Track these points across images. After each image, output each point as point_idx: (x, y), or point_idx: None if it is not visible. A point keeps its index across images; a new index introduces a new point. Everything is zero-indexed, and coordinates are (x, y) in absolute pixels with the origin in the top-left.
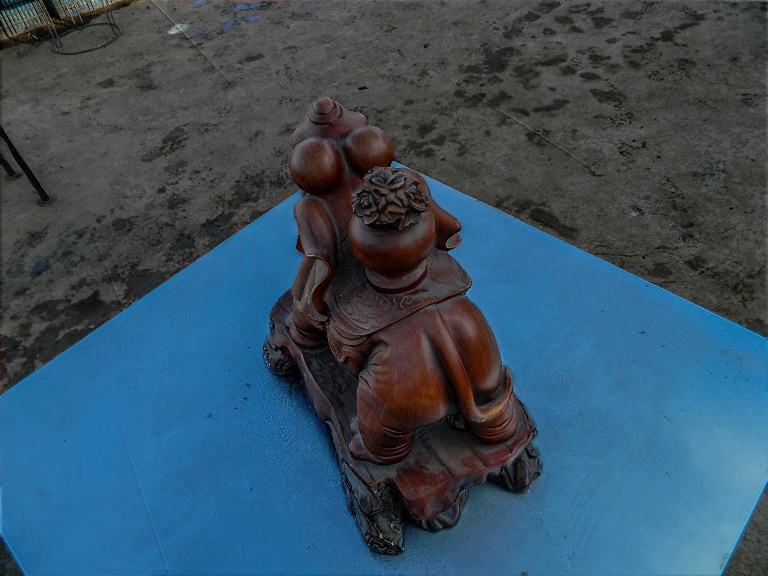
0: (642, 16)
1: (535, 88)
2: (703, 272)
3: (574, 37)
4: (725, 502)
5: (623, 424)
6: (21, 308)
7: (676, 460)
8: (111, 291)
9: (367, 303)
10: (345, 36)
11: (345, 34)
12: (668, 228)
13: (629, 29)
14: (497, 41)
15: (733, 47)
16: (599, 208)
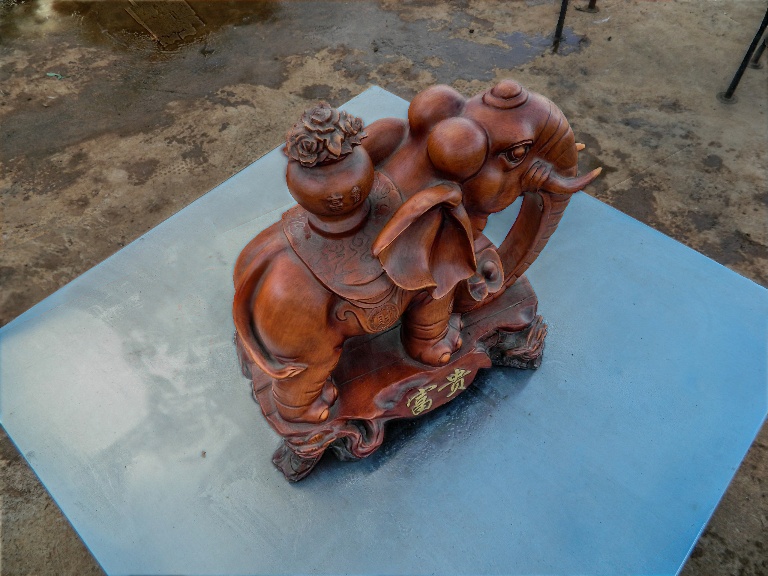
0: None
1: None
2: None
3: None
4: None
5: None
6: (584, 126)
7: None
8: (619, 179)
9: None
10: None
11: None
12: None
13: None
14: None
15: None
16: None
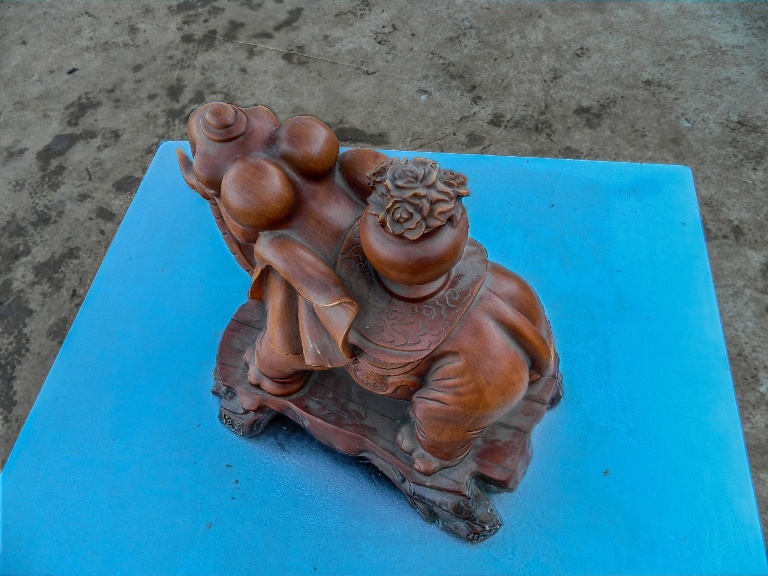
0: None
1: (262, 6)
2: (506, 126)
3: None
4: (699, 315)
5: (591, 295)
6: None
7: (647, 302)
8: None
9: (407, 321)
10: (8, 16)
11: (6, 14)
12: (458, 98)
13: None
14: None
15: None
16: (392, 104)
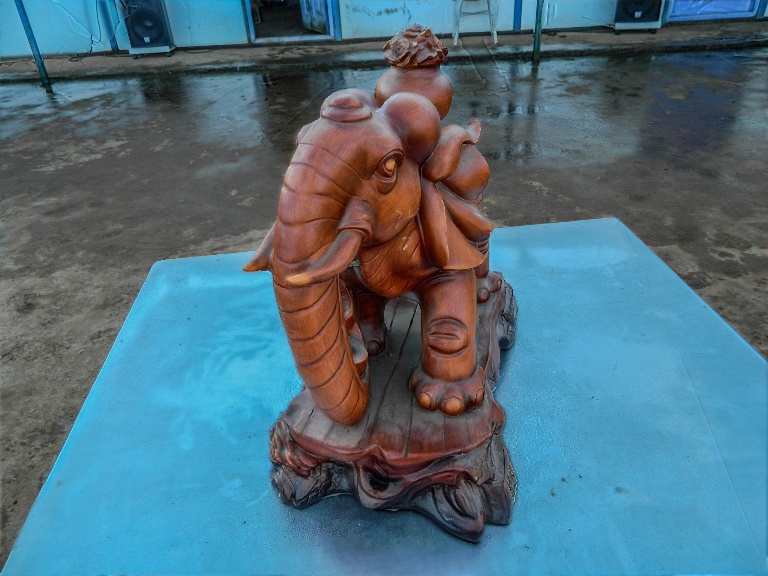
0: None
1: None
2: None
3: None
4: None
5: None
6: None
7: None
8: None
9: None
10: None
11: None
12: None
13: None
14: None
15: None
16: None
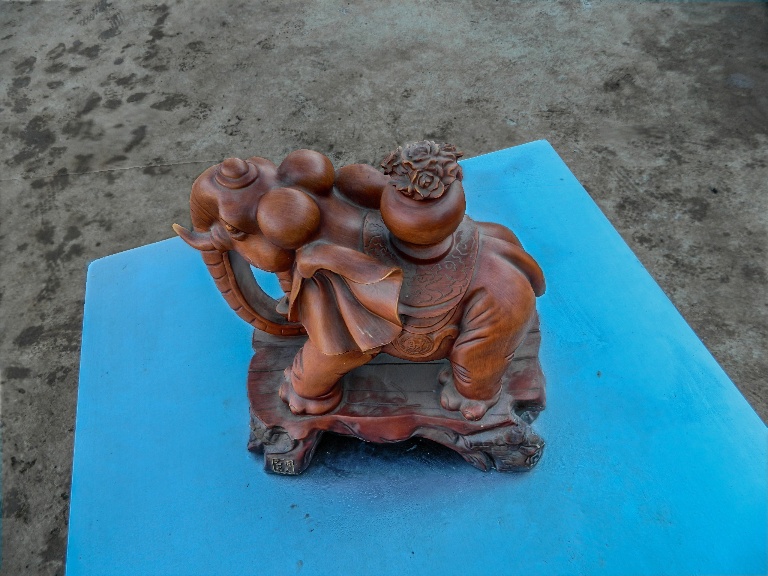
0: (119, 30)
1: (103, 134)
2: None
3: (83, 76)
4: (604, 238)
5: None
6: None
7: (564, 243)
8: None
9: (437, 279)
10: None
11: None
12: None
13: (121, 45)
14: (15, 120)
15: (213, 16)
16: None
